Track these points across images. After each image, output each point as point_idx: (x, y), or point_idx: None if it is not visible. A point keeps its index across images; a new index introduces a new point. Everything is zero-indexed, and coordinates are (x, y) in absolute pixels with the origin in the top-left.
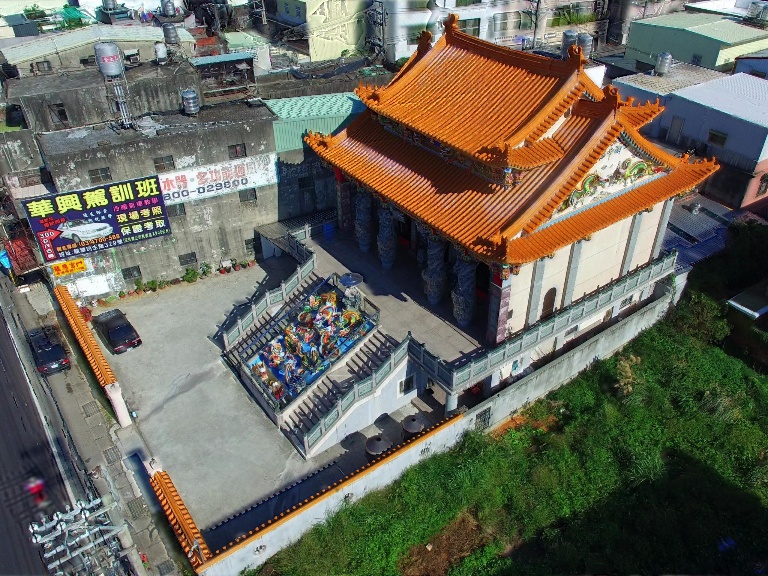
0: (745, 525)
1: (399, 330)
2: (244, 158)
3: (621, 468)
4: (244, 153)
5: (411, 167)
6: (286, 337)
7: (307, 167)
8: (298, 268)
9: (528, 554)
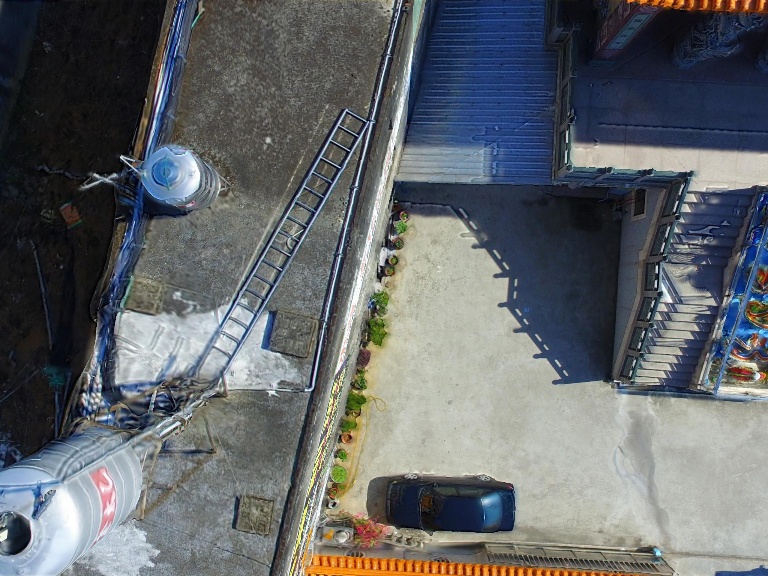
0: None
1: None
2: (389, 138)
3: None
4: None
5: None
6: (748, 317)
7: None
8: None
9: None
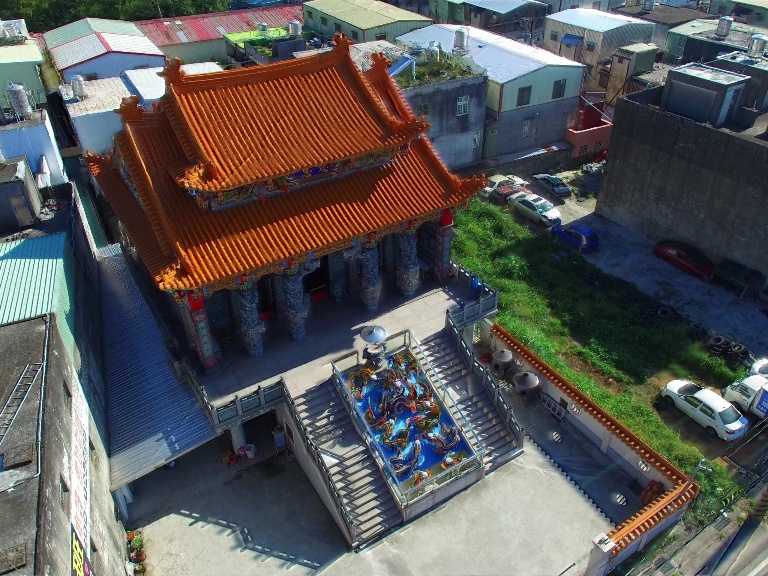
0: (540, 249)
1: (415, 333)
2: (72, 402)
3: (510, 278)
4: (66, 396)
5: (307, 210)
6: (386, 442)
7: (83, 362)
8: (295, 404)
9: (579, 335)
